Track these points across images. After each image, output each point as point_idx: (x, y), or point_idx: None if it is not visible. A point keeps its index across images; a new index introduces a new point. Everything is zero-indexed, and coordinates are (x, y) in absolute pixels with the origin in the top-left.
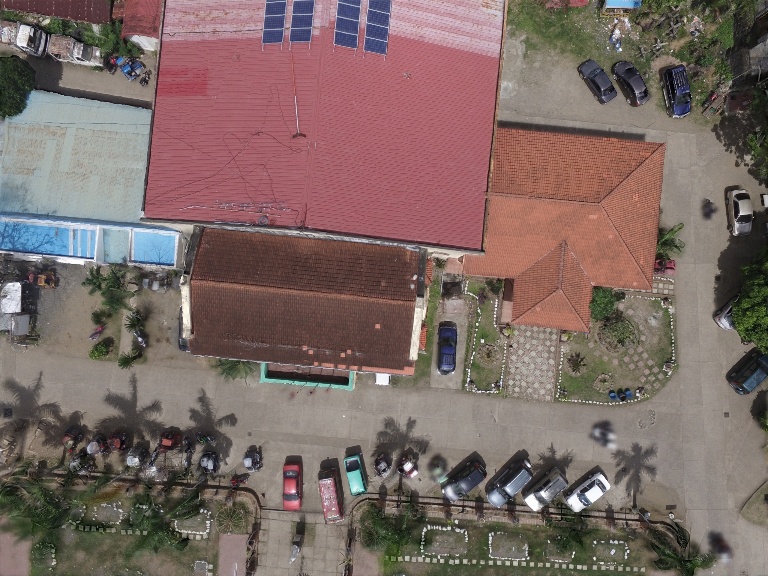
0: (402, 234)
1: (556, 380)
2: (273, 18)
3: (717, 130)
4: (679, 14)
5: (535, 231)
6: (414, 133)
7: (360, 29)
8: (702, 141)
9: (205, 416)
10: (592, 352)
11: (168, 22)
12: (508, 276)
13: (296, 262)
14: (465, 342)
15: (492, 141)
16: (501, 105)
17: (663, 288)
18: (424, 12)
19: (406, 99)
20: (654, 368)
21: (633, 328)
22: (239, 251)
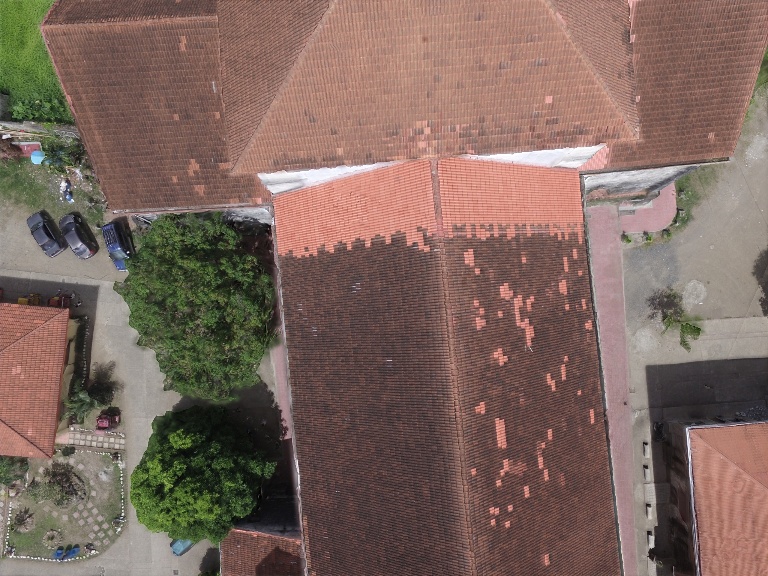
0: None
1: (4, 536)
2: None
3: None
4: None
5: None
6: None
7: None
8: None
9: None
10: (42, 507)
11: None
12: None
13: None
14: None
15: None
16: None
17: (114, 442)
18: None
19: None
20: (104, 524)
21: (82, 484)
22: None
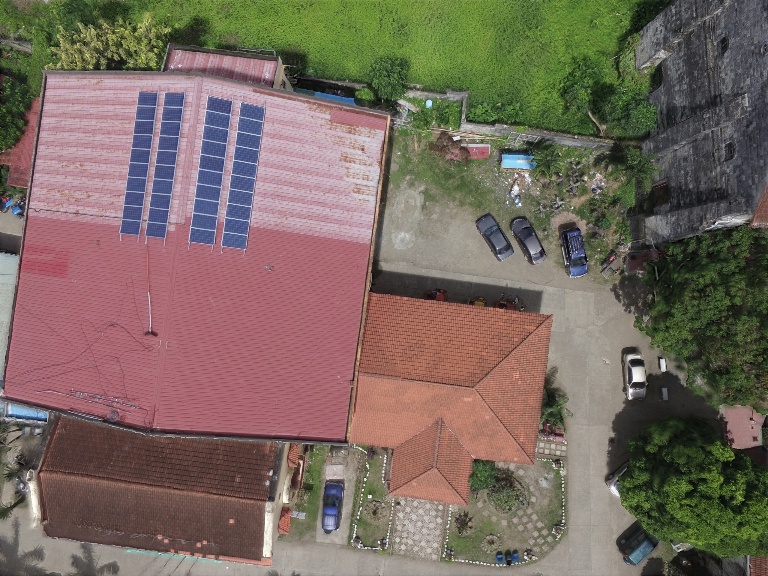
0: (259, 429)
1: (443, 539)
2: (132, 208)
3: (616, 289)
4: (580, 171)
5: (411, 409)
6: (275, 325)
7: (219, 224)
8: (600, 300)
9: (87, 563)
10: (481, 512)
11: (34, 197)
12: (387, 446)
13: (152, 452)
14: (353, 497)
15: (360, 329)
16: (398, 256)
17: (555, 449)
18: (290, 202)
19: (268, 291)
20: (543, 530)
21: (523, 489)
22: (96, 437)
